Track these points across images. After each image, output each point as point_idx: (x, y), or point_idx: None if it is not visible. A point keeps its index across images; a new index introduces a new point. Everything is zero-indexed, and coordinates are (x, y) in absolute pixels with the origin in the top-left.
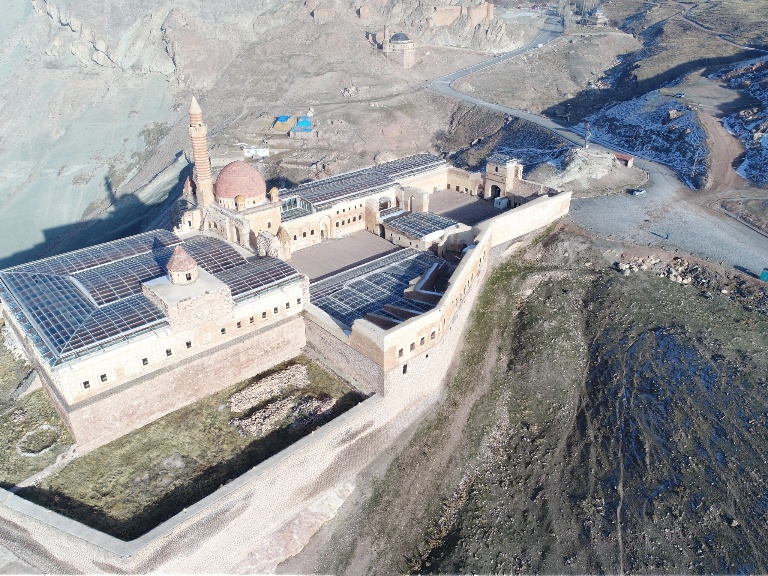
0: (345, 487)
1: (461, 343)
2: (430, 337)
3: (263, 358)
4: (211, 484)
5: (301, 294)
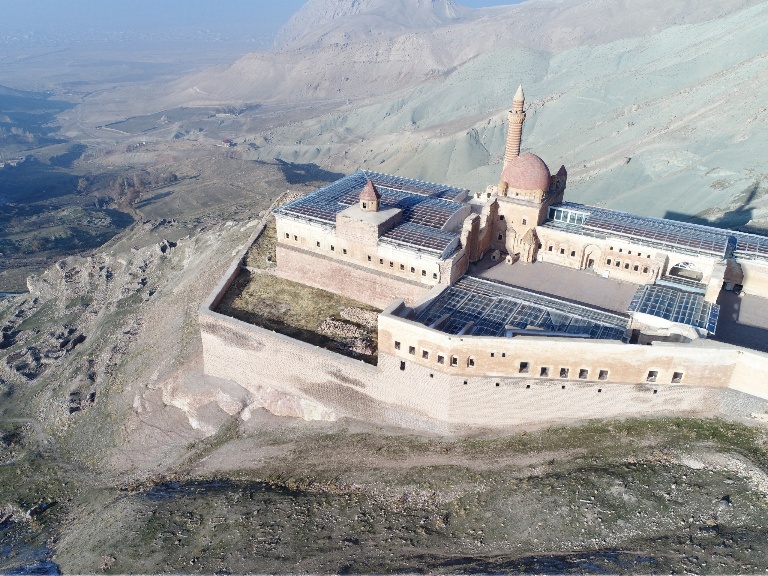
0: (330, 414)
1: (537, 427)
2: (437, 358)
3: None
4: (266, 326)
5: (438, 271)
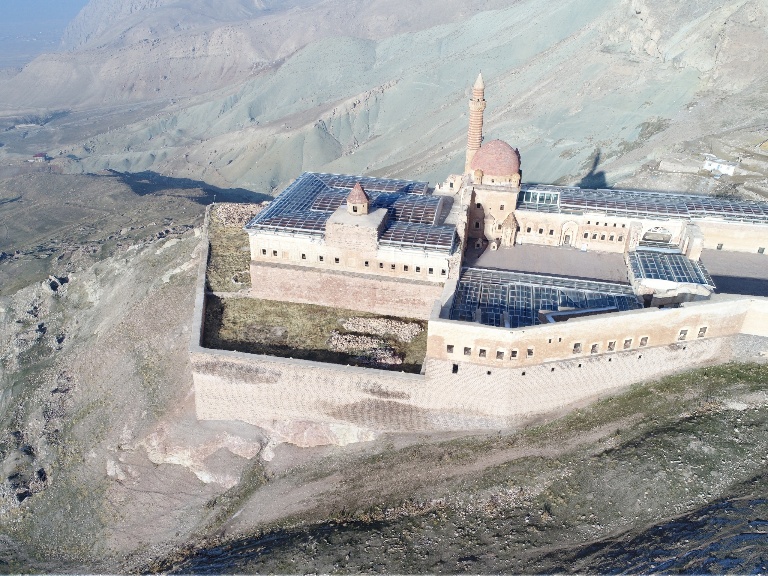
0: (367, 433)
1: (586, 402)
2: (495, 355)
3: (397, 305)
4: (272, 353)
5: (446, 267)
